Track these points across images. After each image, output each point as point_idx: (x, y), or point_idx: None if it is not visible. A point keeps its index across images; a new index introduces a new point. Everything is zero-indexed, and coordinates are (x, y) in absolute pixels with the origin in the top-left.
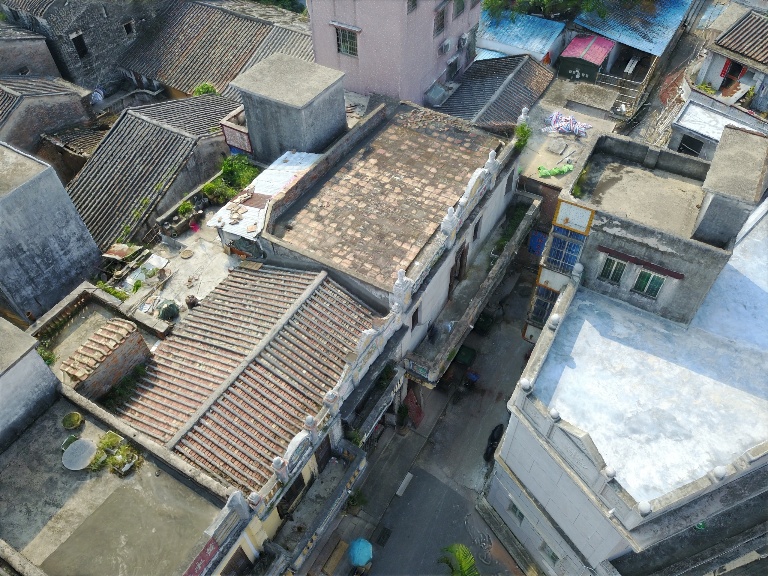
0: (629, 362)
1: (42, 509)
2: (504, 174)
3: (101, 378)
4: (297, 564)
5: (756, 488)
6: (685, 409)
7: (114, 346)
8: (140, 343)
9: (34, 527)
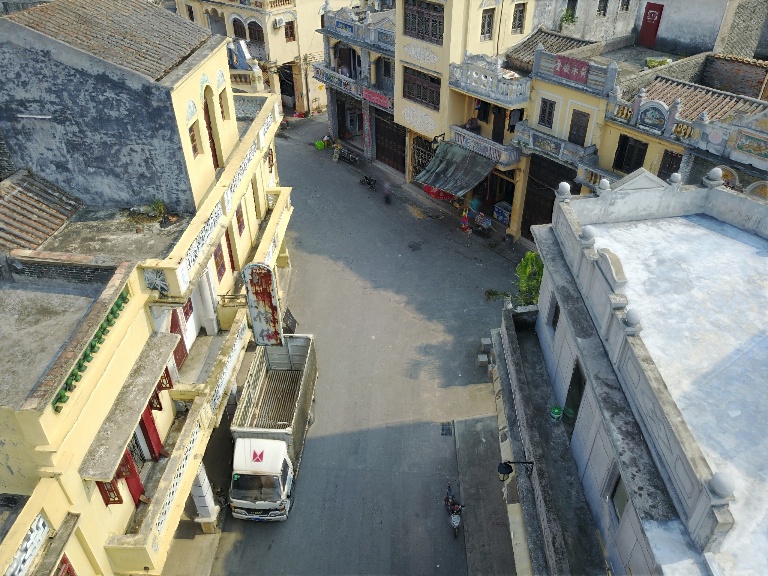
0: None
1: (623, 58)
2: None
3: (722, 73)
4: (579, 173)
5: (572, 316)
6: (691, 306)
7: (747, 61)
8: (759, 84)
9: (613, 57)
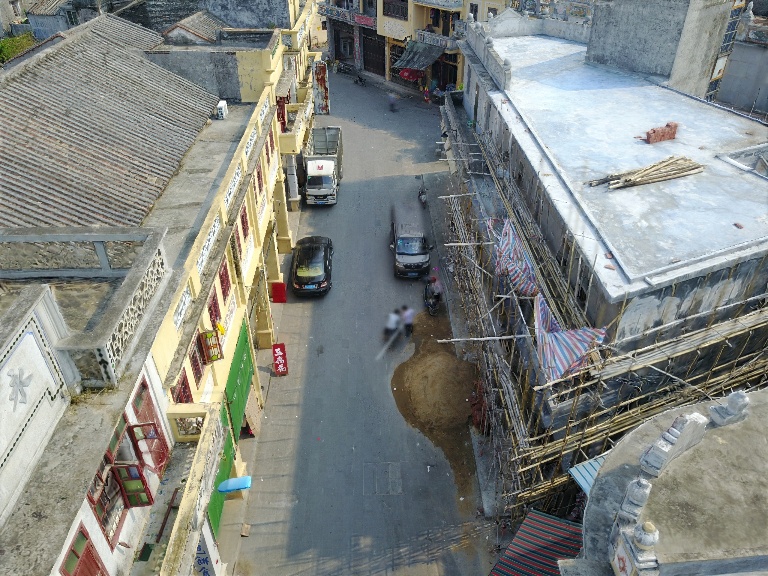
0: (561, 51)
1: None
2: (759, 44)
3: None
4: None
5: None
6: None
7: None
8: None
9: None
